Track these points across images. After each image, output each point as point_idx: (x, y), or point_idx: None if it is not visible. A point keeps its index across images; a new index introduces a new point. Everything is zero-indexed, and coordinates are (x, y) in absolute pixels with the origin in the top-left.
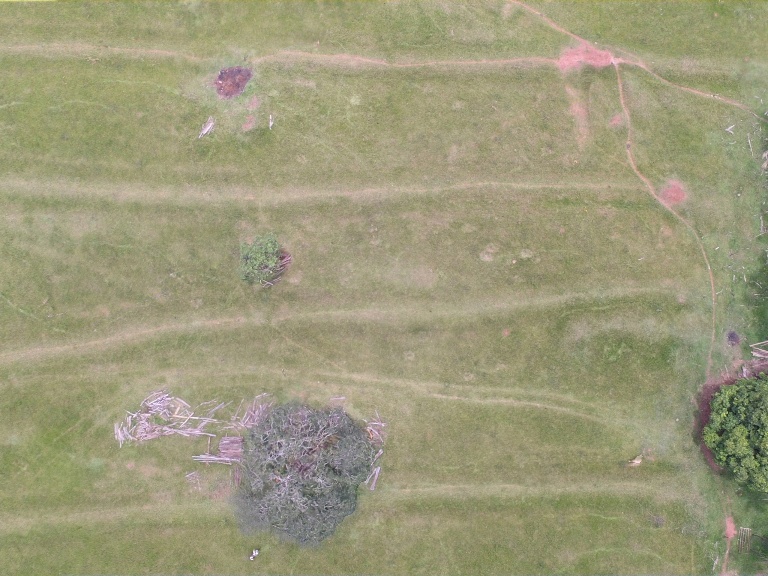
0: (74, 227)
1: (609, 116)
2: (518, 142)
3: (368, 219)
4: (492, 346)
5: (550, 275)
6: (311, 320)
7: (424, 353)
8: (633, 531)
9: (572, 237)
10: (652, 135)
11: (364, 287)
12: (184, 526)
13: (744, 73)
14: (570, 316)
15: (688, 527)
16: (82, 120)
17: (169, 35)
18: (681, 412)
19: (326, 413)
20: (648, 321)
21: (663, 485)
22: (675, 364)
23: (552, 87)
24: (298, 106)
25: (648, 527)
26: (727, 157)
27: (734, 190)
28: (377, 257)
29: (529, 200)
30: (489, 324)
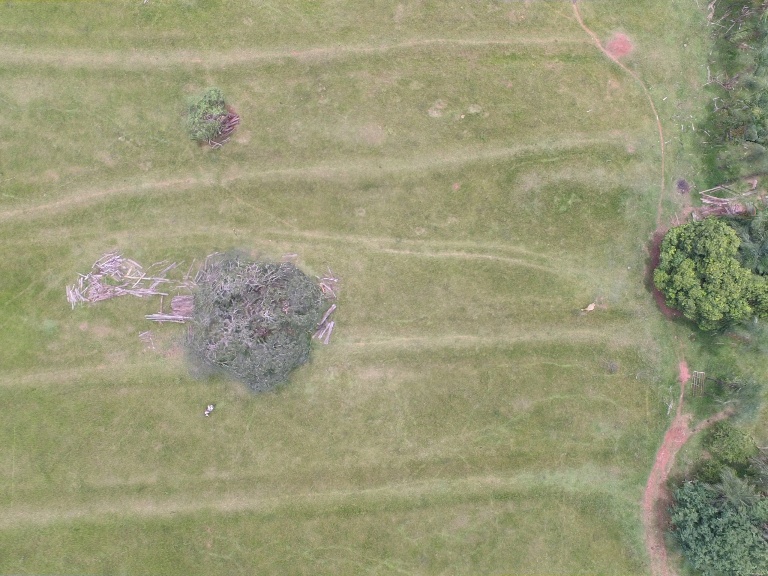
0: (21, 93)
1: None
2: None
3: (316, 79)
4: (443, 200)
5: (499, 129)
6: (261, 179)
7: (375, 209)
8: (587, 378)
9: (520, 91)
10: None
11: (313, 145)
12: (139, 386)
13: None
14: (520, 169)
15: (642, 373)
16: None
17: None
18: (632, 260)
19: (276, 265)
20: (597, 171)
21: (616, 332)
22: (626, 213)
23: None
24: None
25: (602, 374)
26: (673, 9)
27: (680, 41)
28: (326, 115)
29: (476, 56)
30: (439, 179)
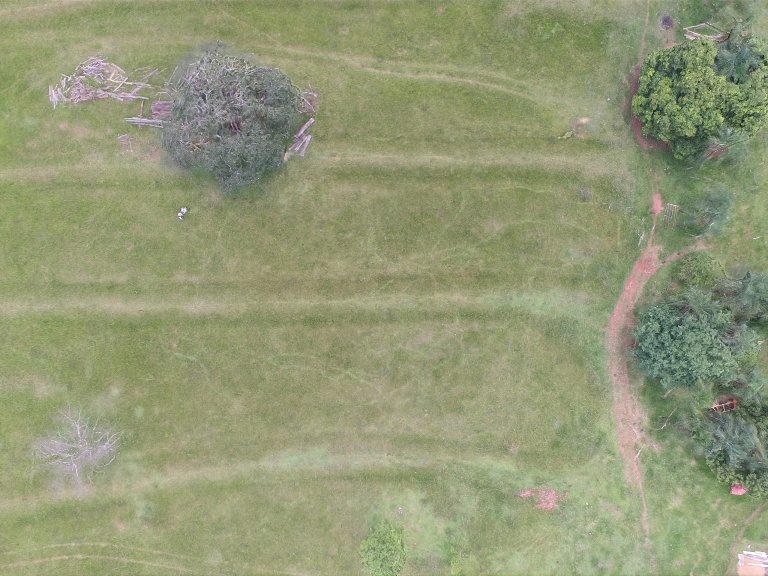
0: None
1: None
2: None
3: None
4: (426, 23)
5: None
6: None
7: (358, 28)
8: (560, 204)
9: None
10: None
11: None
12: (115, 187)
13: None
14: None
15: (615, 203)
16: None
17: None
18: (612, 92)
19: None
20: (582, 2)
21: (592, 160)
22: (608, 46)
23: None
24: None
25: (575, 201)
26: None
27: None
28: None
29: None
30: (424, 2)
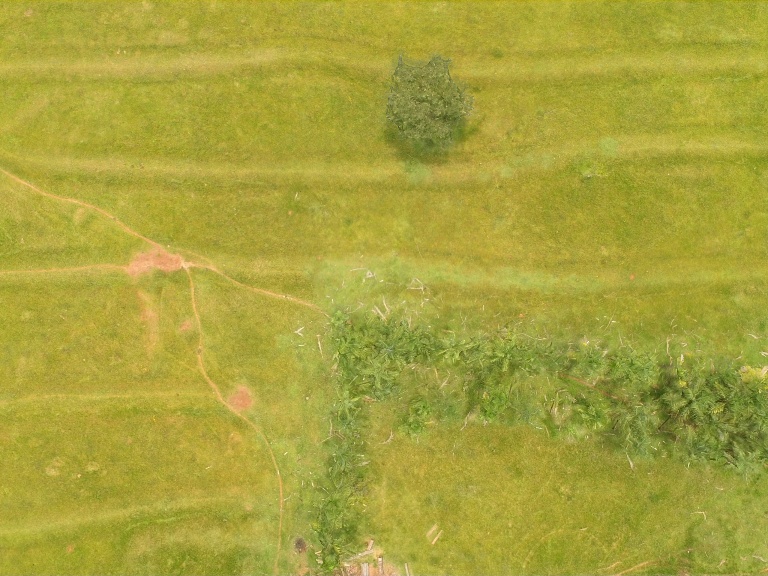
0: None
1: (179, 321)
2: (86, 352)
3: None
4: (56, 563)
5: (117, 487)
6: None
7: None
8: None
9: (139, 448)
10: (221, 340)
11: None
12: None
13: (316, 272)
14: (135, 529)
15: None
16: None
17: None
18: None
19: None
20: (212, 532)
21: None
22: (242, 574)
23: (122, 294)
24: None
25: None
26: (297, 359)
27: (302, 394)
28: None
29: (98, 410)
30: (53, 541)
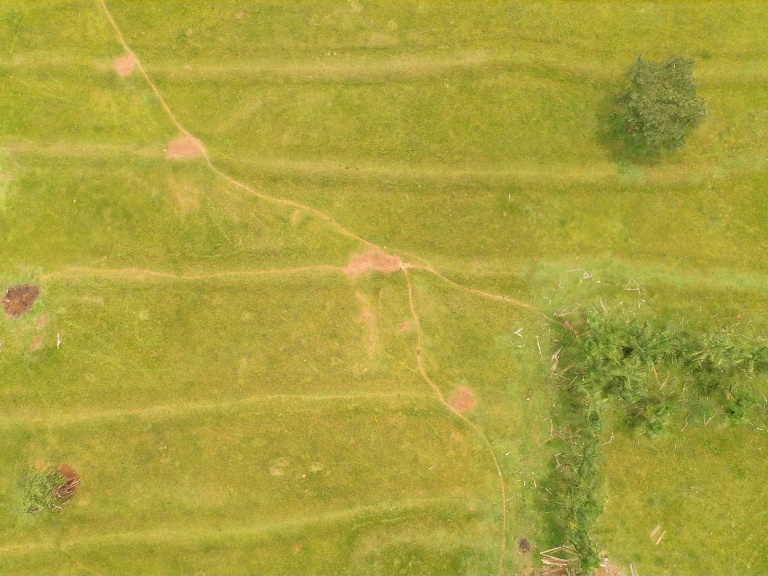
0: None
1: (398, 322)
2: (307, 352)
3: (158, 436)
4: (283, 563)
5: (341, 487)
6: (101, 543)
7: (215, 573)
8: None
9: (362, 448)
10: (441, 341)
11: (154, 507)
12: None
13: (533, 273)
14: (360, 529)
15: None
16: None
17: None
18: None
19: None
20: (438, 532)
21: None
22: (467, 574)
23: (341, 295)
24: (86, 323)
25: None
26: (516, 360)
27: (523, 394)
28: (166, 476)
29: (319, 411)
30: (280, 540)
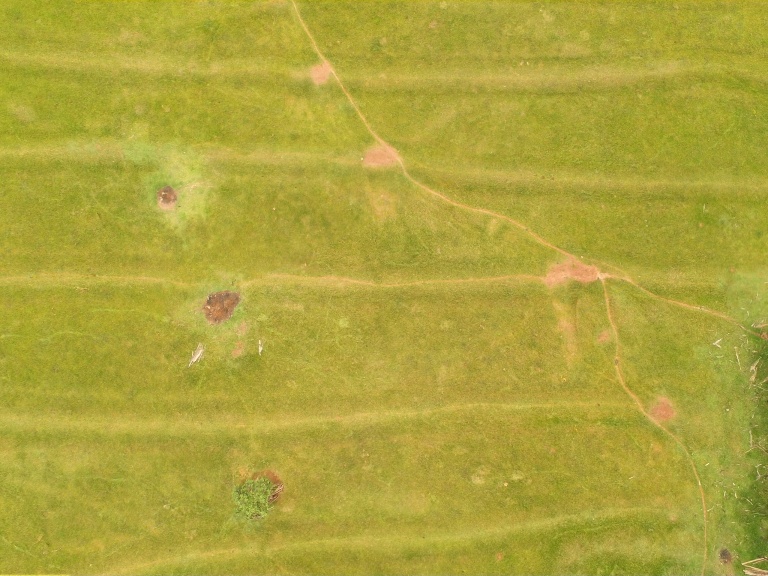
0: (67, 462)
1: (597, 332)
2: (507, 361)
3: (359, 444)
4: (486, 571)
5: (542, 496)
6: (305, 549)
7: None
8: None
9: (563, 457)
10: (640, 351)
11: (357, 514)
12: None
13: (730, 284)
14: (562, 538)
15: None
16: (72, 351)
17: (157, 260)
18: None
19: None
20: (640, 542)
21: None
22: None
23: (539, 304)
24: (287, 330)
25: None
26: (715, 371)
27: (723, 405)
28: (369, 483)
29: (519, 420)
30: (482, 548)
